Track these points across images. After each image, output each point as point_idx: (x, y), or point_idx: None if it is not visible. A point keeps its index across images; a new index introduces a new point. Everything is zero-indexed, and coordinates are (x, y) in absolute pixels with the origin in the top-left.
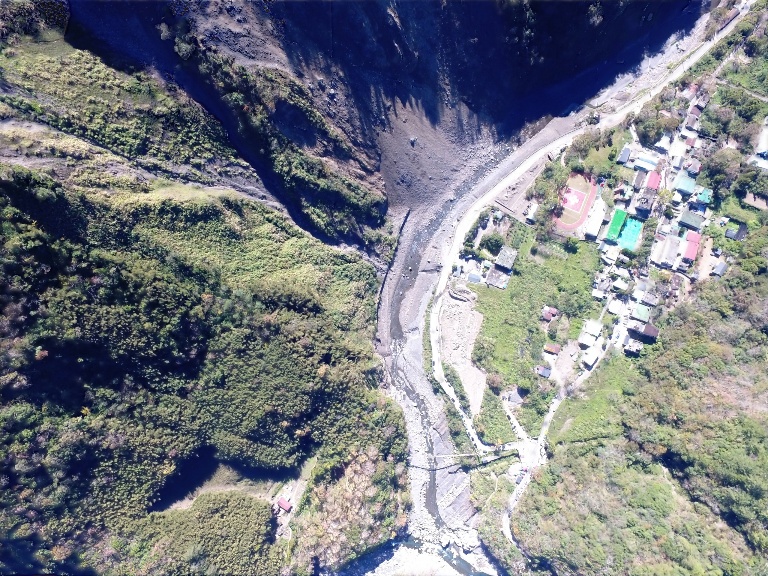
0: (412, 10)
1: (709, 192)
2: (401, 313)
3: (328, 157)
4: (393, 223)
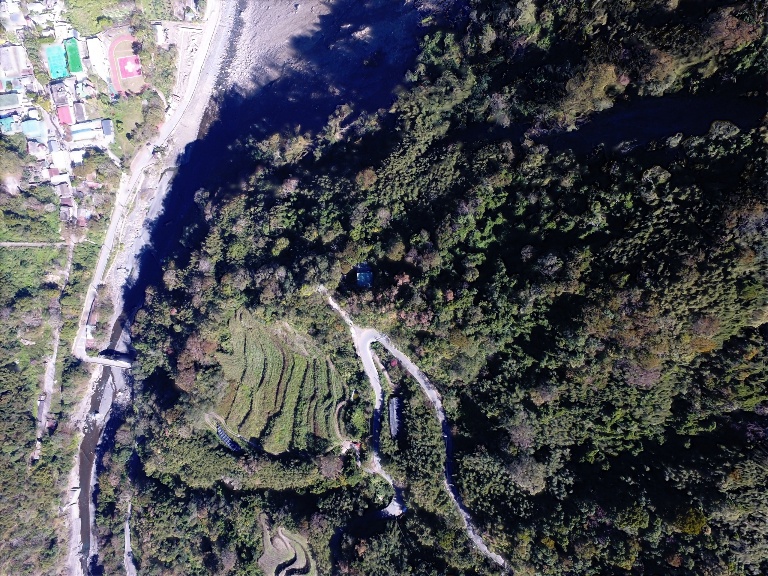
0: (352, 58)
1: (5, 129)
2: None
3: None
4: None
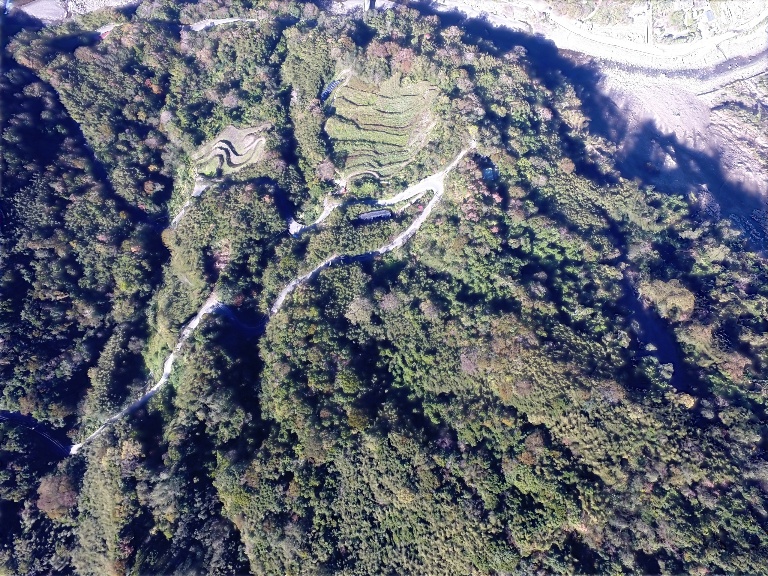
0: None
1: None
2: (762, 50)
3: (761, 146)
4: (715, 99)
